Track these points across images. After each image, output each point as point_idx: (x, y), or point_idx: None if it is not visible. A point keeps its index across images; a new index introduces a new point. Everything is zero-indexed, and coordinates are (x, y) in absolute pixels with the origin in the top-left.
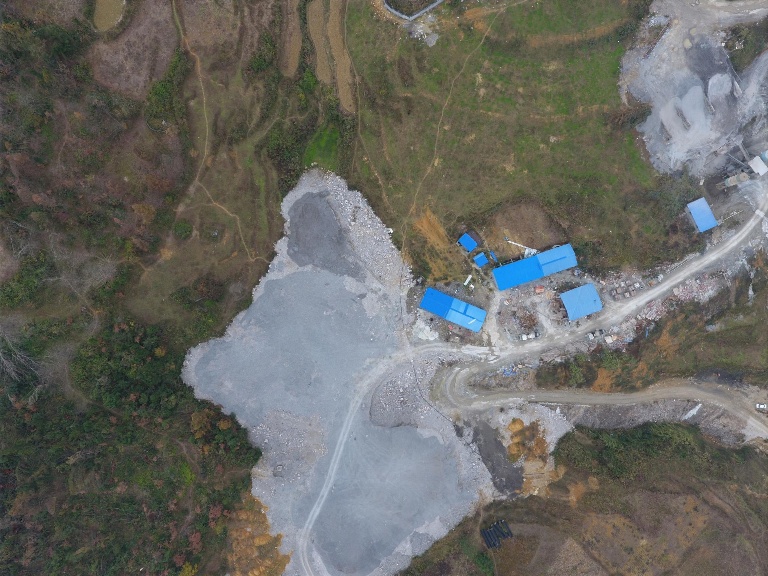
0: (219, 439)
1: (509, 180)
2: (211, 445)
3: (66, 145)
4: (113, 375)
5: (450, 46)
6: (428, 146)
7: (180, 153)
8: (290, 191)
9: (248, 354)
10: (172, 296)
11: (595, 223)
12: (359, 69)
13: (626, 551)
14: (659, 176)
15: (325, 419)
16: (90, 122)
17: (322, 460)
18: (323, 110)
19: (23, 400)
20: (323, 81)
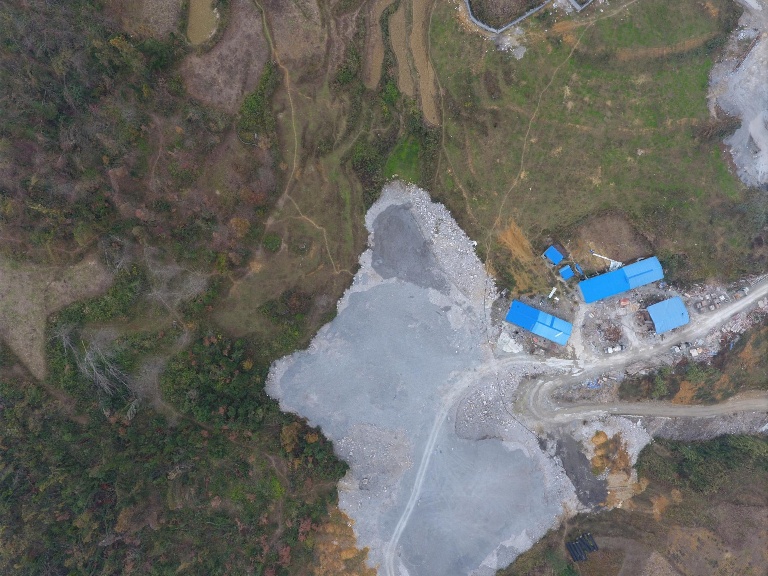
0: (308, 452)
1: (595, 193)
2: (301, 459)
3: (160, 159)
4: (200, 388)
5: (538, 59)
6: (514, 159)
7: (271, 166)
8: (374, 203)
9: (333, 367)
10: (260, 309)
11: (680, 236)
12: (443, 81)
13: (711, 564)
14: (746, 189)
15: (411, 432)
16: (184, 136)
17: (408, 473)
18: (404, 122)
19: (121, 415)
20: (405, 93)
